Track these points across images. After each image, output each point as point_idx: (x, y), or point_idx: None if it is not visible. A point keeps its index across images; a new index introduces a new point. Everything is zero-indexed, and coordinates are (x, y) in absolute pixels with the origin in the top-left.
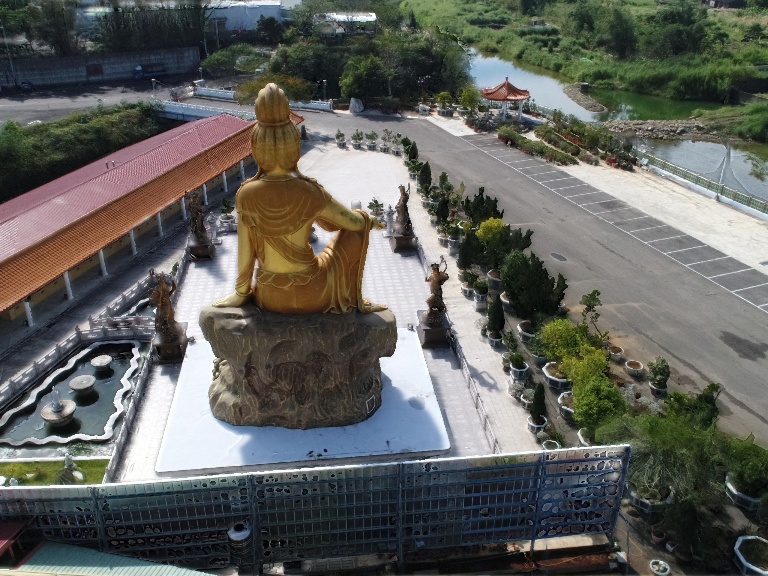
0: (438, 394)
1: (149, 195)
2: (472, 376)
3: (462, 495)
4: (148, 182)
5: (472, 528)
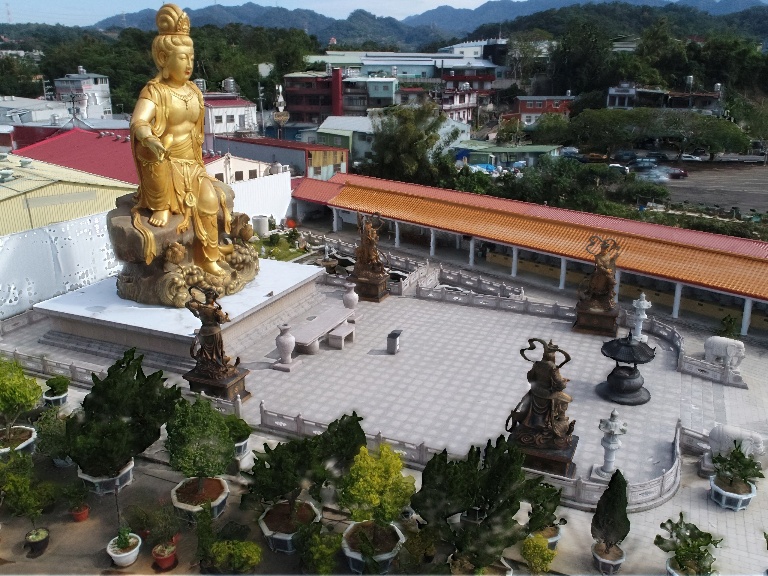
0: None
1: (692, 260)
2: None
3: None
4: (722, 252)
5: None
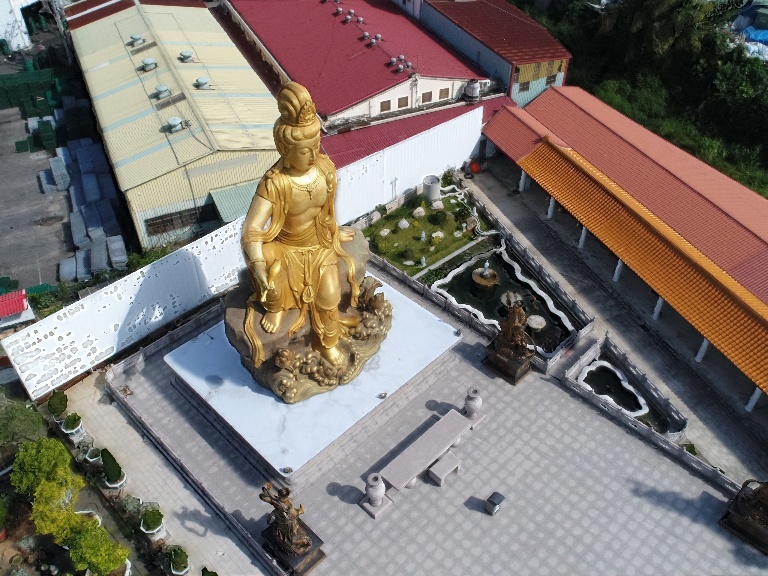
0: (231, 463)
1: None
2: (214, 518)
3: (128, 306)
4: None
5: (128, 333)
